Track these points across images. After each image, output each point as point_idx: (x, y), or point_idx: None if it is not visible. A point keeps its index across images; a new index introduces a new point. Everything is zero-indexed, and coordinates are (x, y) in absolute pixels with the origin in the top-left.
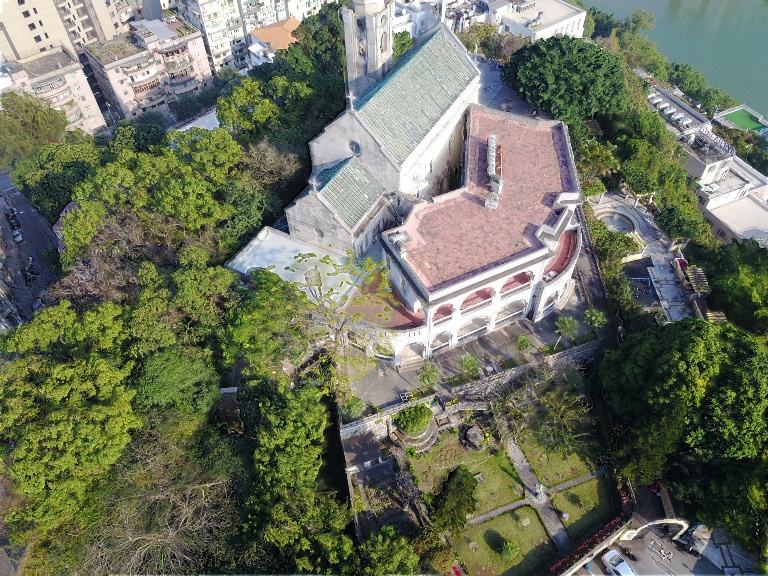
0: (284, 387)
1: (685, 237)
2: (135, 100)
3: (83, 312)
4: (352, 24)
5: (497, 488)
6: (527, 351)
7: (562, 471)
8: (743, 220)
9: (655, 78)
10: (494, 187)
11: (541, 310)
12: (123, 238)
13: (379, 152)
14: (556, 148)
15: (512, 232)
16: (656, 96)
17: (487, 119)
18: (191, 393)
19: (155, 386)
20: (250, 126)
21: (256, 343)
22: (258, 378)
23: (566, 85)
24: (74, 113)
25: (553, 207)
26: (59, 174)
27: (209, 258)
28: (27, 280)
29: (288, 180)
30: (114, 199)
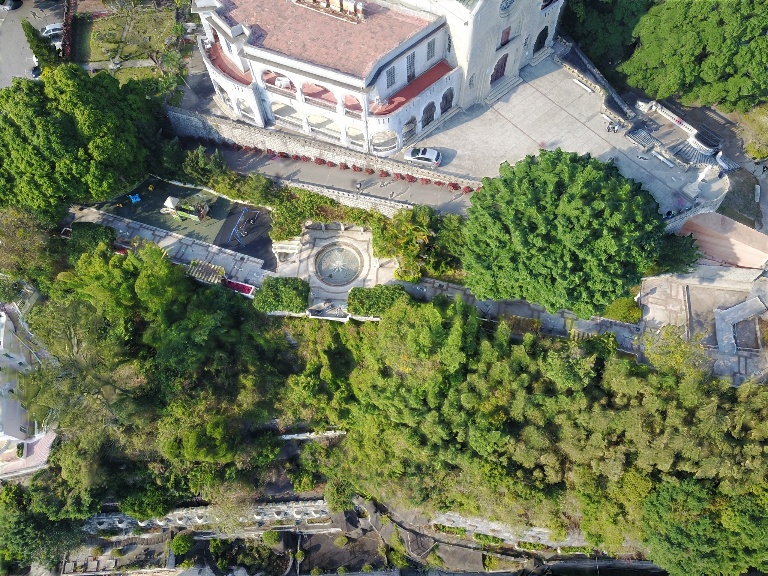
0: None
1: None
2: None
3: None
4: None
5: (135, 47)
6: (191, 61)
7: (120, 83)
8: None
9: None
10: None
11: None
12: None
13: None
14: (329, 67)
15: None
16: None
17: (412, 30)
18: None
19: None
20: None
21: None
22: None
23: None
24: None
25: None
26: None
27: None
28: None
29: None
30: None
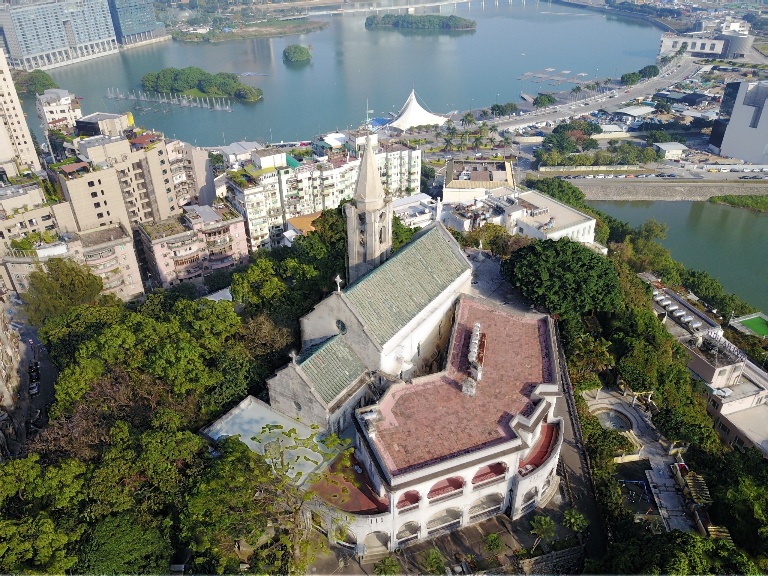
0: (231, 568)
1: (684, 440)
2: (174, 272)
3: (46, 467)
4: (354, 218)
5: None
6: (502, 552)
7: None
8: (761, 428)
9: (668, 282)
10: (473, 373)
11: (519, 507)
12: (111, 396)
13: (362, 332)
14: (540, 340)
15: (487, 420)
16: (665, 299)
17: (476, 308)
18: (137, 566)
19: (99, 554)
20: (257, 300)
21: (211, 516)
22: (207, 556)
23: (560, 282)
24: (117, 279)
25: (531, 397)
26: (80, 332)
27: (187, 423)
28: (29, 433)
29: (278, 352)
30: (113, 359)
